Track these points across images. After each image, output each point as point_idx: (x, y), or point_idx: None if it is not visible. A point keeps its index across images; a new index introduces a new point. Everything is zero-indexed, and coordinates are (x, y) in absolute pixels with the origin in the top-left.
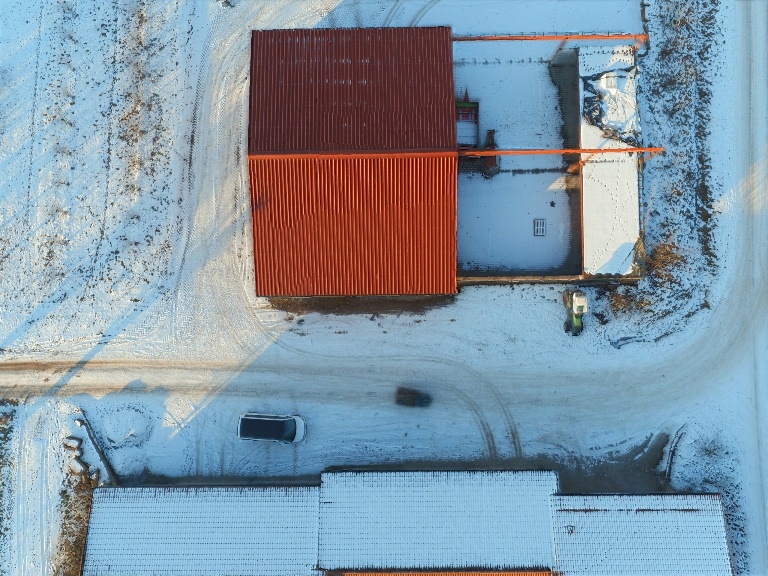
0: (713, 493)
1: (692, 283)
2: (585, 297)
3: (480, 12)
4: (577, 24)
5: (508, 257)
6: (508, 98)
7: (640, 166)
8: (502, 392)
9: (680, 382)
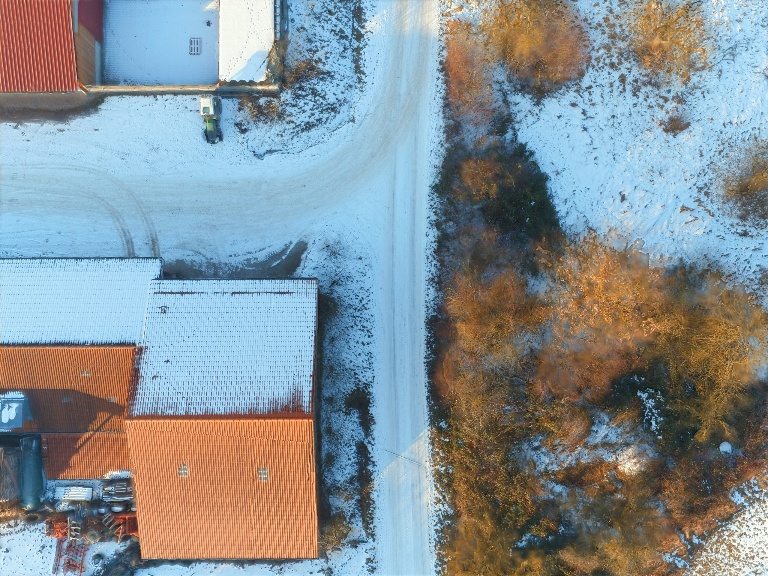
0: (311, 278)
1: (339, 98)
2: (210, 98)
3: None
4: None
5: (164, 75)
6: None
7: None
8: (144, 200)
9: (320, 192)
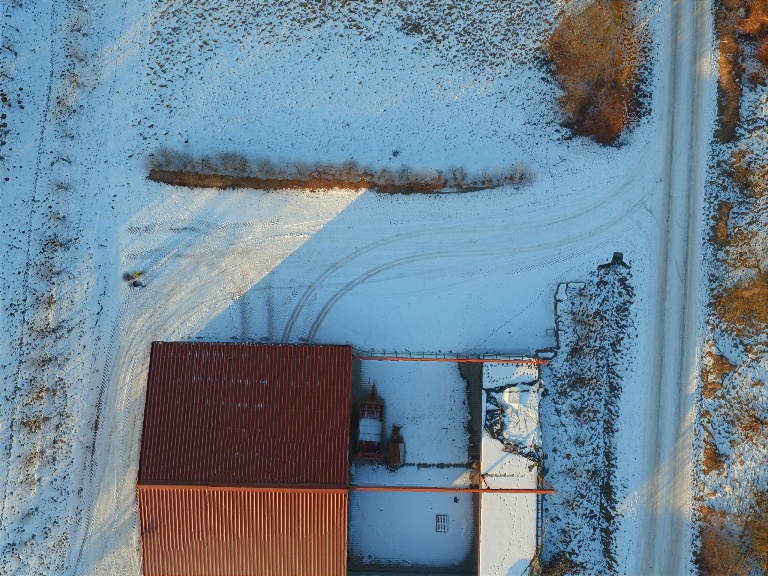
0: None
1: None
2: None
3: (392, 302)
4: (489, 316)
5: (409, 552)
6: (416, 390)
7: (539, 482)
8: None
9: None
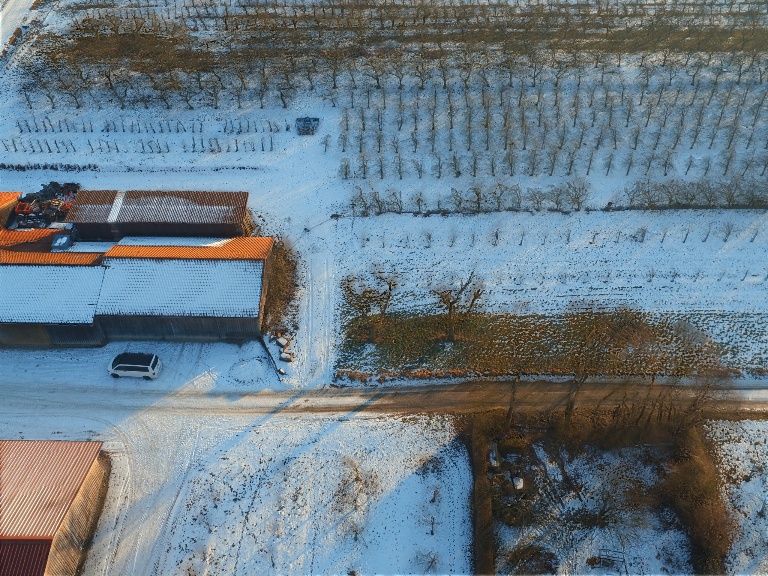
0: None
1: None
2: None
3: None
4: None
5: None
6: None
7: None
8: None
9: None
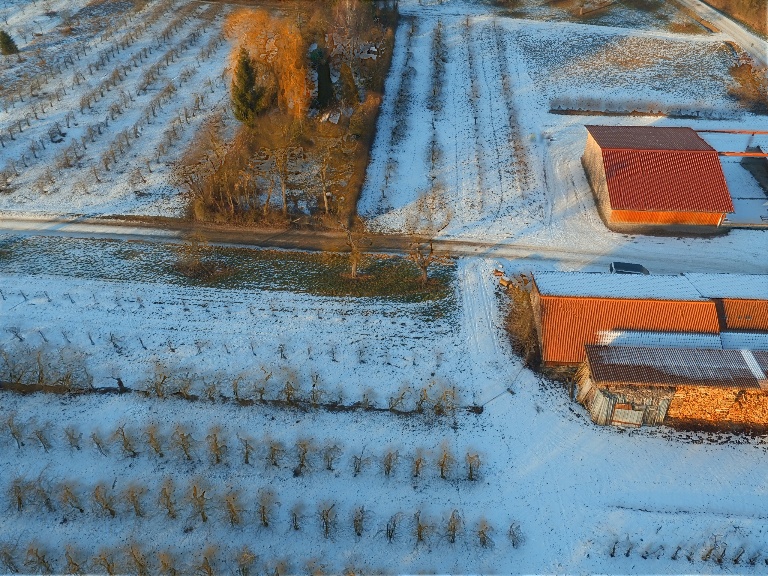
0: None
1: None
2: None
3: None
4: None
5: None
6: None
7: None
8: None
9: None
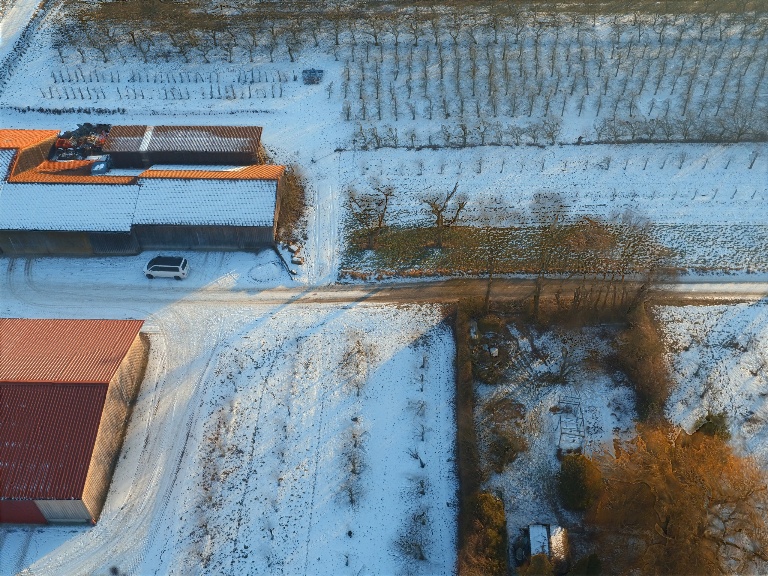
0: None
1: None
2: None
3: None
4: None
5: None
6: None
7: None
8: (6, 289)
9: None
